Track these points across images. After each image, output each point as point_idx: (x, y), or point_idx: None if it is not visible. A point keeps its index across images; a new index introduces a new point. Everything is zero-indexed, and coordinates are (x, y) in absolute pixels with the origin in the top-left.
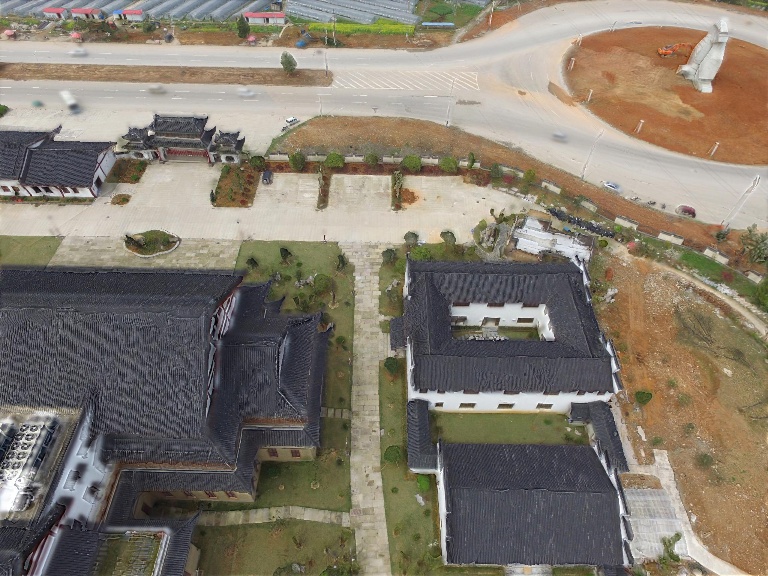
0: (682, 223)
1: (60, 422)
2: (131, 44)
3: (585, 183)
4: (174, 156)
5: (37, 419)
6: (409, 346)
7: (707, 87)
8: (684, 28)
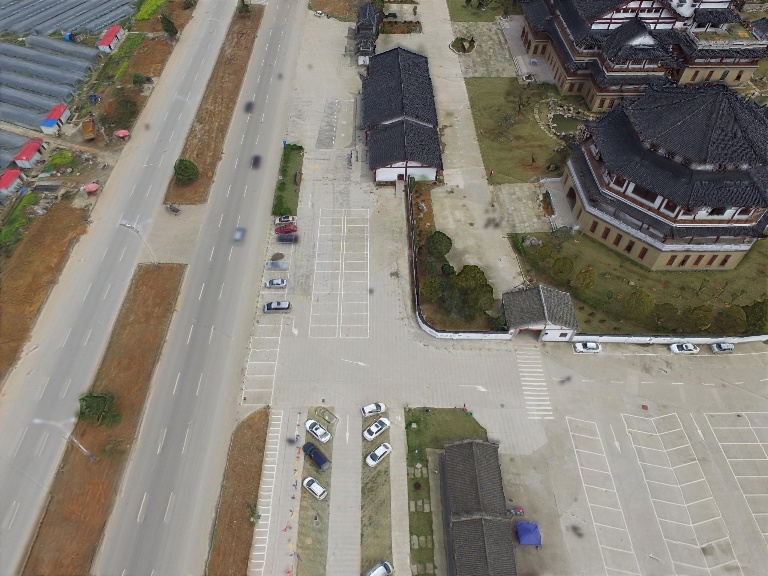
0: None
1: None
2: (147, 104)
3: None
4: None
5: None
6: None
7: None
8: None
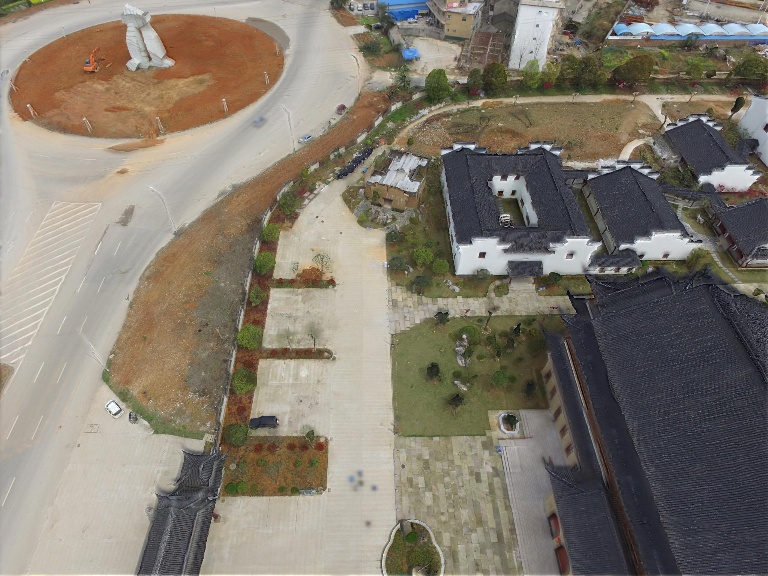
0: (355, 114)
1: None
2: None
3: (299, 152)
4: None
5: None
6: (571, 240)
7: (170, 60)
8: (41, 49)
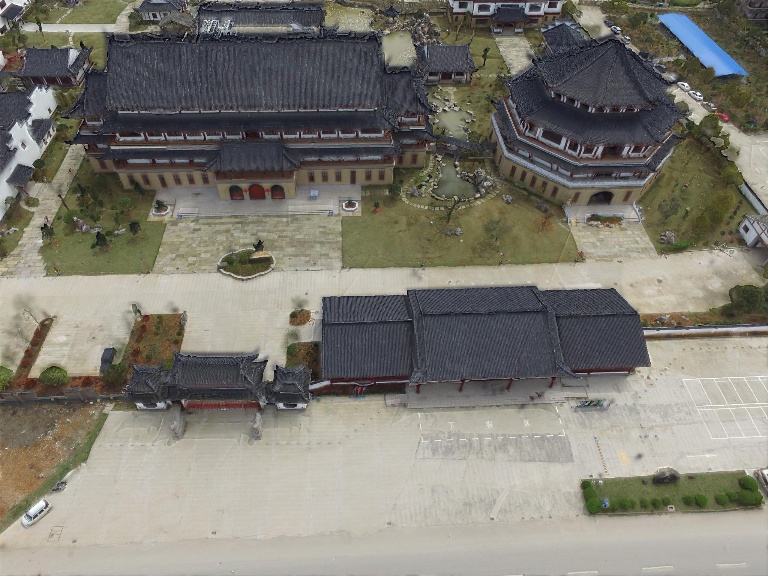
0: None
1: None
2: None
3: None
4: (249, 401)
5: None
6: None
7: None
8: None
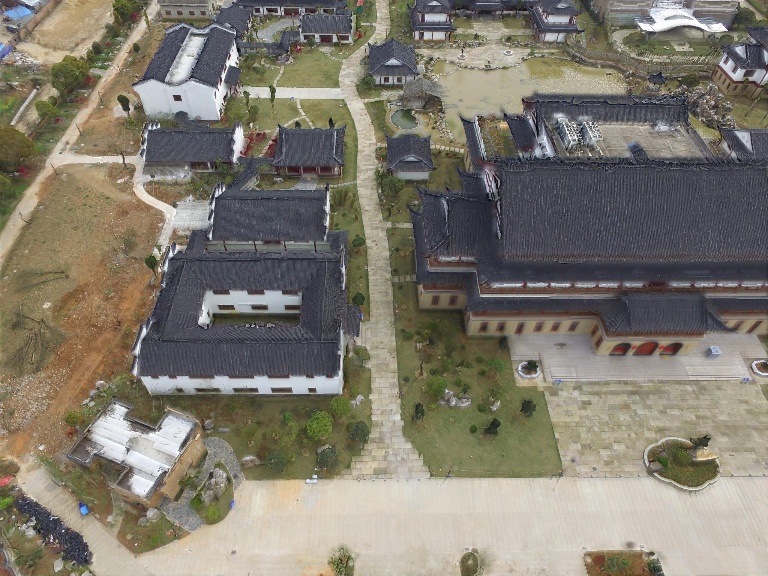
0: None
1: (570, 160)
2: None
3: None
4: None
5: (585, 161)
6: None
7: None
8: None
